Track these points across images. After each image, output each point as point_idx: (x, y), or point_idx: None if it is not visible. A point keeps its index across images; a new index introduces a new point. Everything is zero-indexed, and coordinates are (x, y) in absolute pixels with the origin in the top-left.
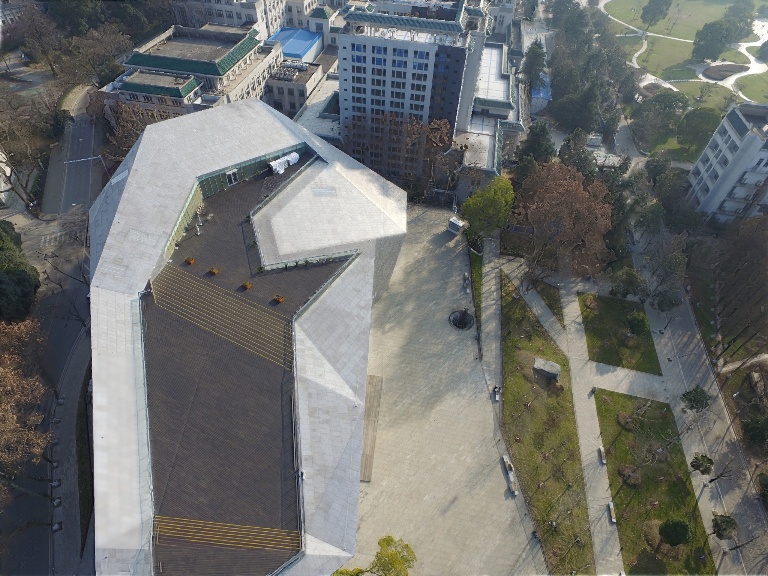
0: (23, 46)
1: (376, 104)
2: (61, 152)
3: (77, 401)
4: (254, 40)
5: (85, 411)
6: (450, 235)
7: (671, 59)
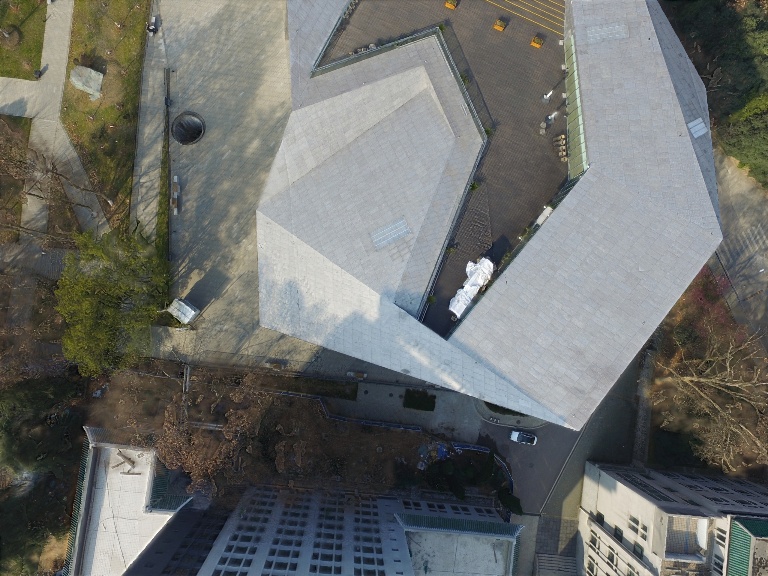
0: None
1: (330, 569)
2: None
3: None
4: None
5: None
6: (197, 298)
7: None
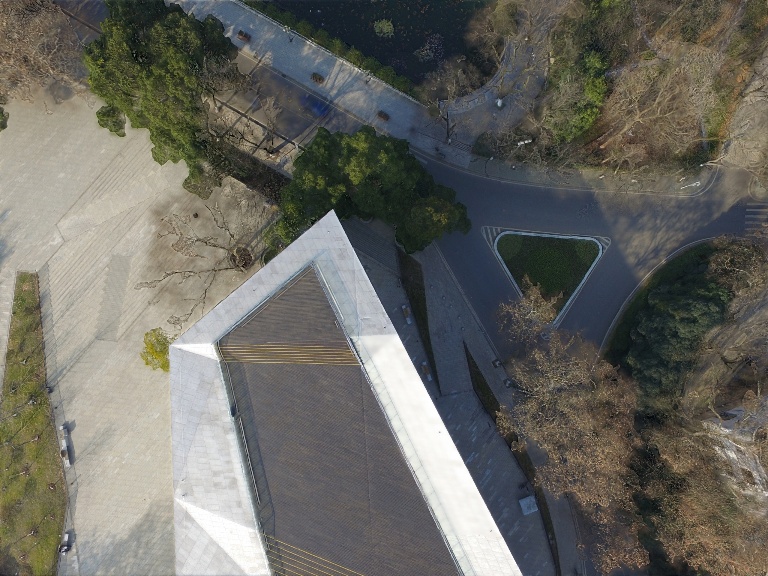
0: None
1: None
2: None
3: None
4: None
5: (527, 473)
6: None
7: None
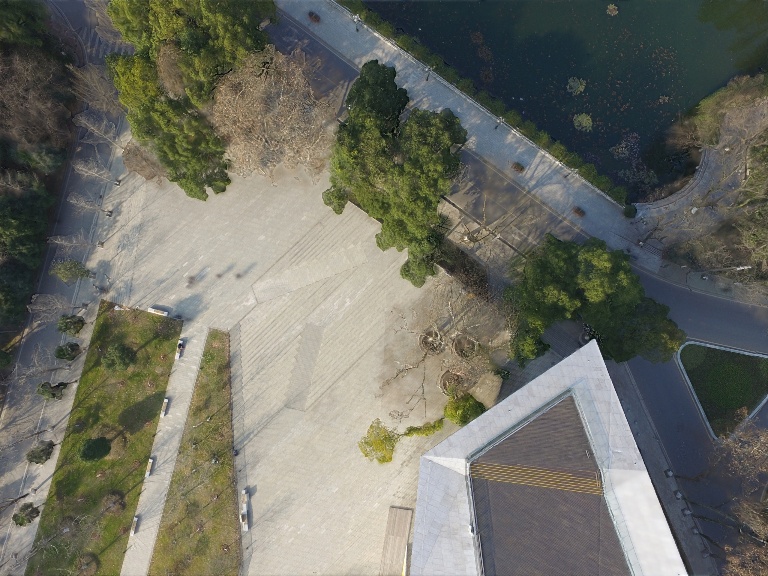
0: None
1: None
2: None
3: None
4: None
5: None
6: None
7: None
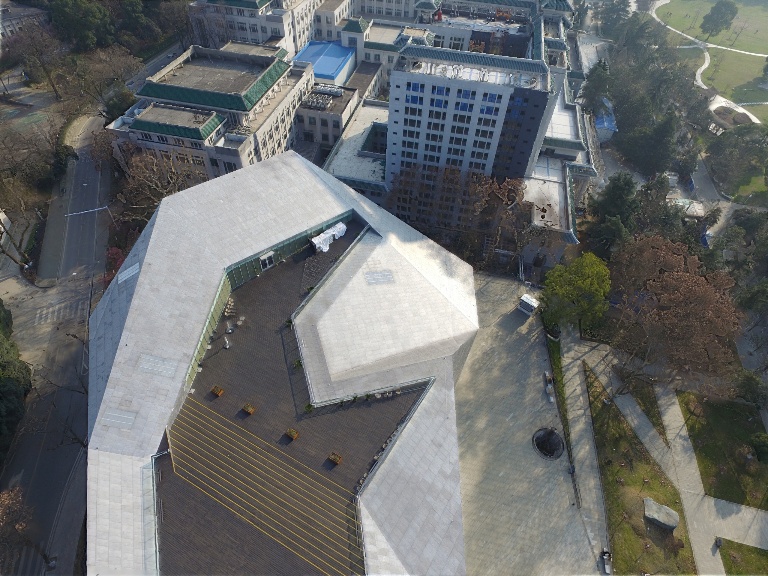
0: (23, 65)
1: (430, 150)
2: (63, 195)
3: (72, 563)
4: (284, 64)
5: None
6: (521, 316)
7: (739, 77)
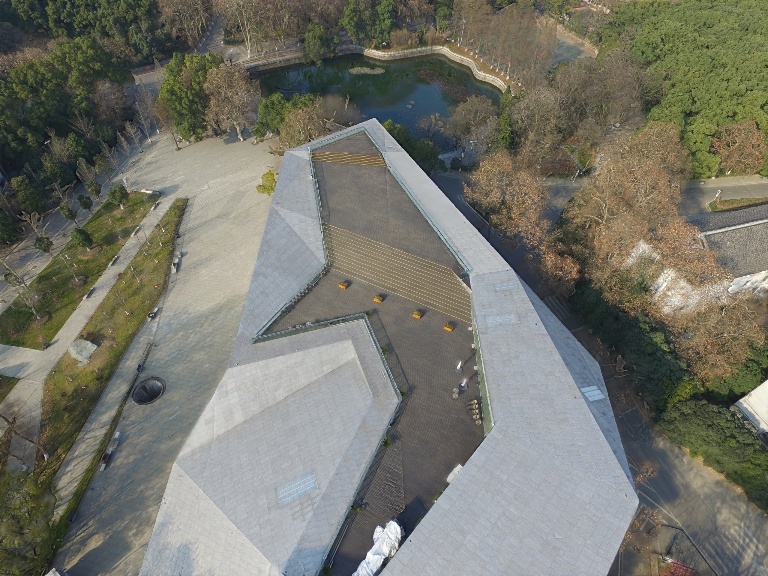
0: None
1: None
2: None
3: None
4: None
5: None
6: (80, 572)
7: None
